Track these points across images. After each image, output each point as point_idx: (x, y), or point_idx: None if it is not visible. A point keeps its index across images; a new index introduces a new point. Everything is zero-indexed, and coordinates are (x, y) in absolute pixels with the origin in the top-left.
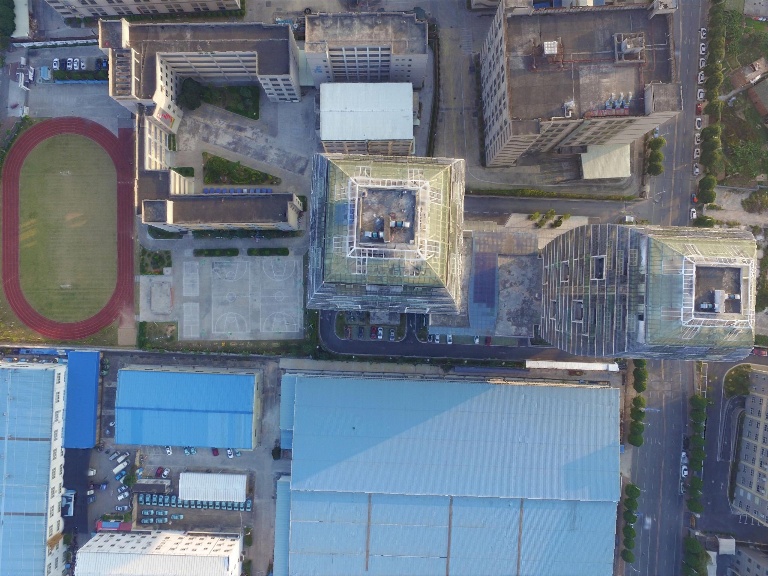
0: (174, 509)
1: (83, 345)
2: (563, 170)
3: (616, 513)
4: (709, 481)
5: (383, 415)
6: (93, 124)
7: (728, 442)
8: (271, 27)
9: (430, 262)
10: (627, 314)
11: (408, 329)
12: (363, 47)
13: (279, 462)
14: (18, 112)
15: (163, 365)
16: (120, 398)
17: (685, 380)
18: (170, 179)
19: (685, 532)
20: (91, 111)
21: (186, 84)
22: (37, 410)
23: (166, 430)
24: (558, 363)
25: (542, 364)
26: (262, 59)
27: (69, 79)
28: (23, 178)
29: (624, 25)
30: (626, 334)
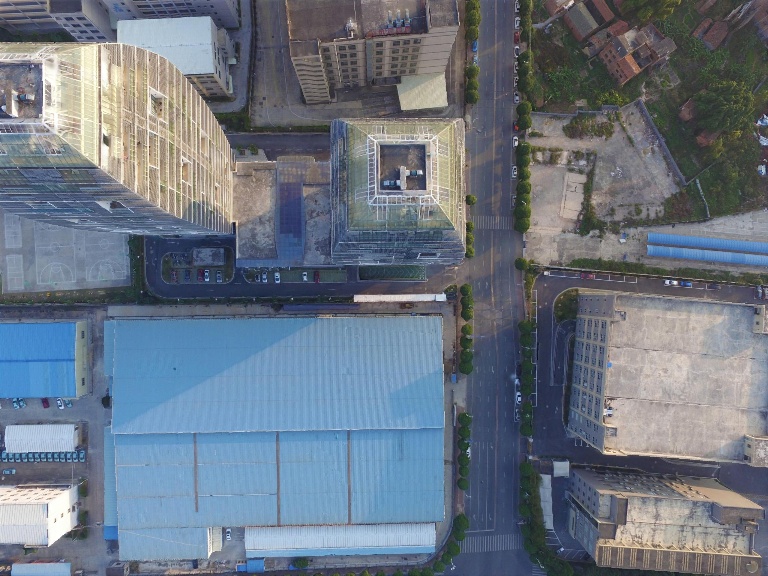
0: (6, 464)
1: None
2: (385, 104)
3: None
4: (543, 406)
5: (204, 354)
6: None
7: (561, 367)
8: None
9: (65, 137)
10: (338, 205)
11: (236, 270)
12: None
13: None
14: None
15: None
16: None
17: (516, 307)
18: None
19: (522, 458)
20: None
21: None
22: None
23: None
24: (386, 296)
25: (370, 298)
26: None
27: None
28: None
29: None
30: (338, 225)
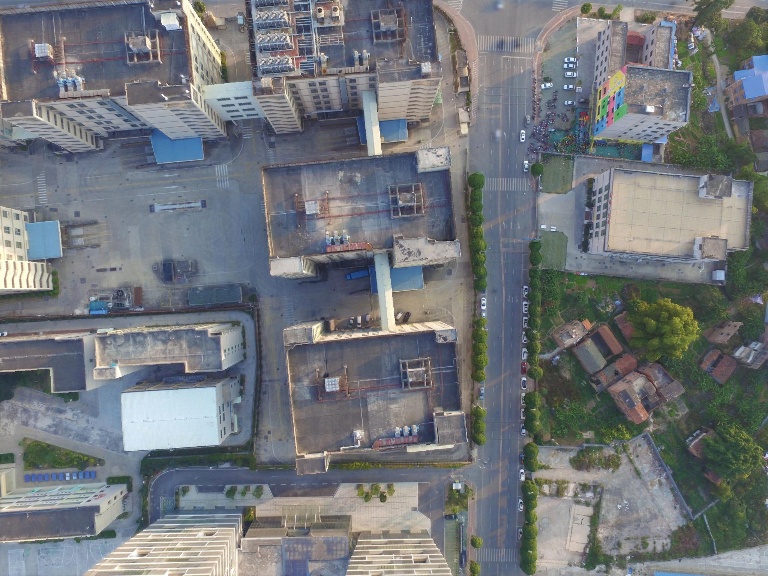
0: None
1: None
2: None
3: None
4: None
5: None
6: None
7: None
8: (66, 341)
9: None
10: None
11: None
12: None
13: None
14: None
15: None
16: None
17: None
18: None
19: None
20: None
21: None
22: None
23: None
24: None
25: None
26: (58, 374)
27: None
28: None
29: (411, 348)
30: None
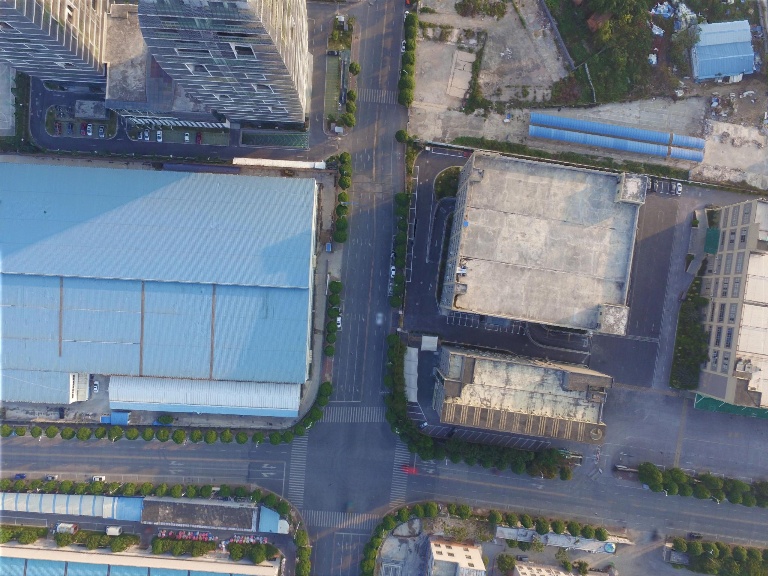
0: None
1: None
2: None
3: None
4: (418, 282)
5: (76, 200)
6: None
7: (438, 244)
8: None
9: None
10: None
11: (119, 127)
12: None
13: None
14: None
15: None
16: None
17: (396, 182)
18: None
19: (393, 332)
20: None
21: None
22: None
23: None
24: (265, 160)
25: (249, 161)
26: None
27: None
28: None
29: None
30: None
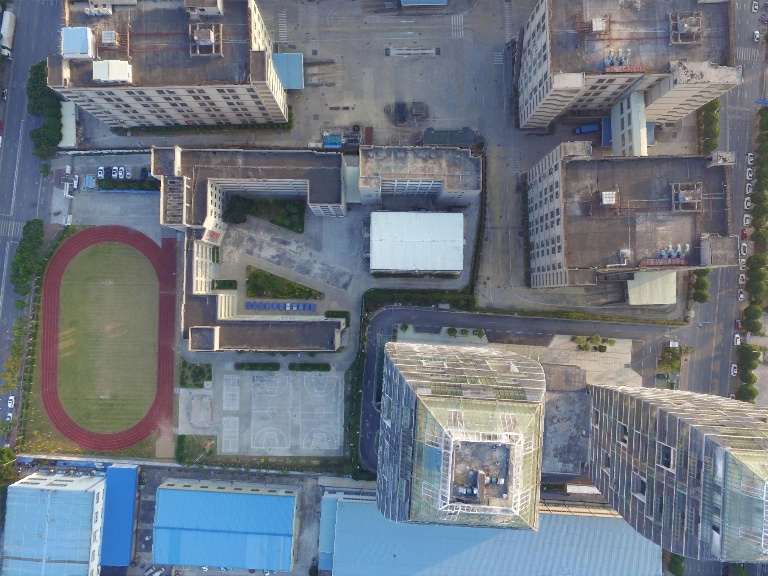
0: None
1: (120, 457)
2: (607, 292)
3: None
4: None
5: (424, 543)
6: (136, 233)
7: (767, 570)
8: (323, 155)
9: (522, 514)
10: (700, 522)
11: None
12: (416, 180)
13: None
14: (61, 219)
15: (201, 479)
16: (159, 517)
17: None
18: (217, 304)
19: None
20: (135, 220)
21: (234, 203)
22: (76, 532)
23: (204, 551)
24: None
25: (583, 489)
26: (314, 187)
27: (114, 188)
28: (64, 286)
29: (681, 173)
30: (699, 542)
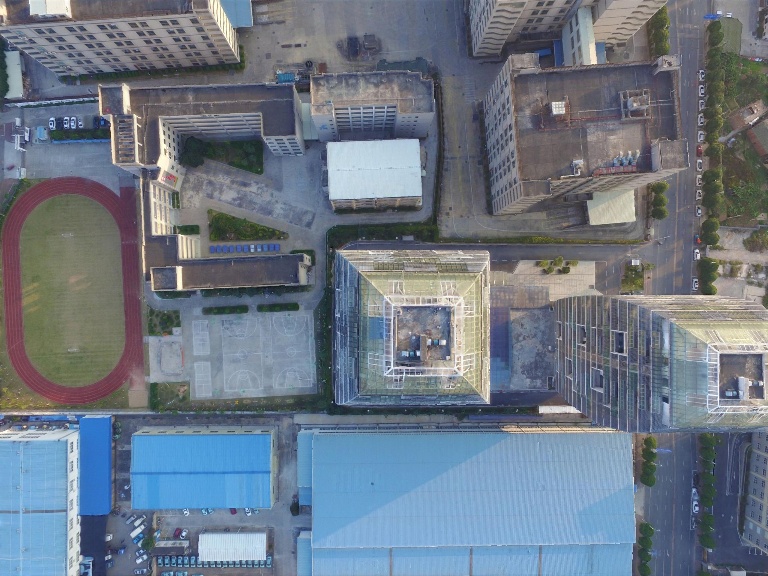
0: (194, 569)
1: (93, 409)
2: (569, 215)
3: (631, 552)
4: (719, 515)
5: (401, 469)
6: (93, 184)
7: (736, 476)
8: (275, 87)
9: (466, 376)
10: (651, 395)
11: None
12: (369, 106)
13: (297, 517)
14: (15, 174)
15: (176, 426)
16: (135, 463)
17: None
18: (178, 244)
19: (697, 566)
20: (91, 170)
21: (189, 144)
22: (51, 482)
23: (183, 493)
24: (570, 407)
25: (555, 409)
26: (267, 120)
27: (67, 139)
28: (23, 241)
29: (629, 81)
30: (651, 415)
